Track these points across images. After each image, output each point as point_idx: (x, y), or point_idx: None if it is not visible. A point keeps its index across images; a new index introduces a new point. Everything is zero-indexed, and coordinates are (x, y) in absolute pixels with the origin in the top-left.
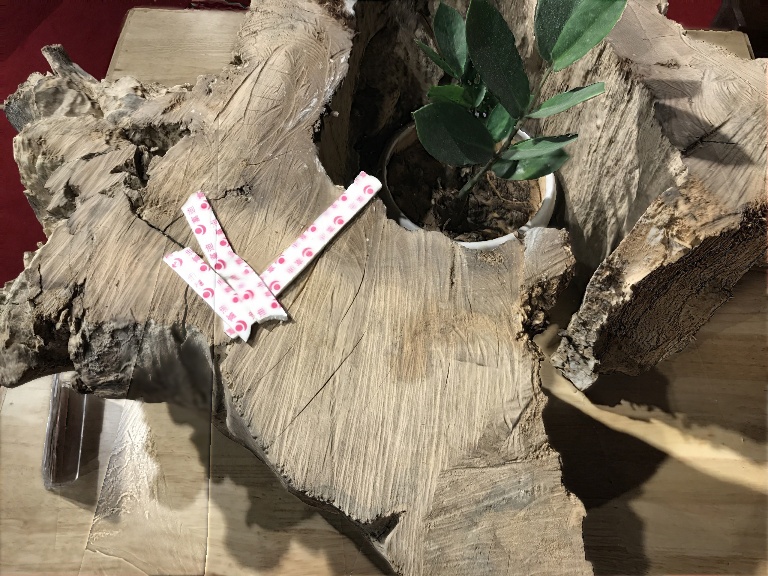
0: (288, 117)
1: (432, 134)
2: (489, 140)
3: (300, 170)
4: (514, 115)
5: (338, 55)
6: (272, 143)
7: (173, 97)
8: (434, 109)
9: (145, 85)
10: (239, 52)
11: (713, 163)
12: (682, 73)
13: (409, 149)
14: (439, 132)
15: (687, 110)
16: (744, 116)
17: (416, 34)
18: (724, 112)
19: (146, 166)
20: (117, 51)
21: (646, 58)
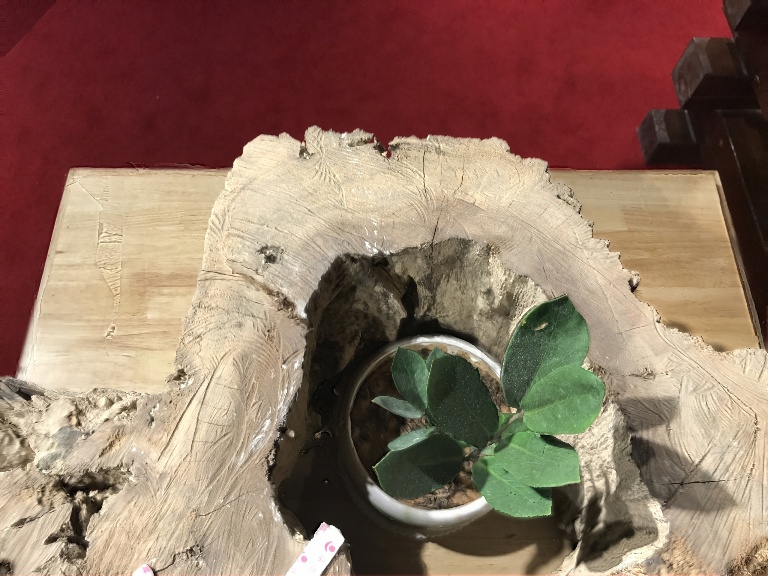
0: (239, 448)
1: (396, 476)
2: (457, 449)
3: (255, 521)
4: (483, 444)
5: (291, 359)
6: (223, 484)
7: (111, 433)
8: (397, 453)
9: (80, 402)
10: (182, 364)
11: (695, 512)
12: (658, 385)
13: (374, 375)
14: (403, 470)
15: (666, 443)
16: (725, 443)
17: (375, 289)
18: (704, 441)
19: (85, 521)
20: (58, 225)
21: (620, 361)
